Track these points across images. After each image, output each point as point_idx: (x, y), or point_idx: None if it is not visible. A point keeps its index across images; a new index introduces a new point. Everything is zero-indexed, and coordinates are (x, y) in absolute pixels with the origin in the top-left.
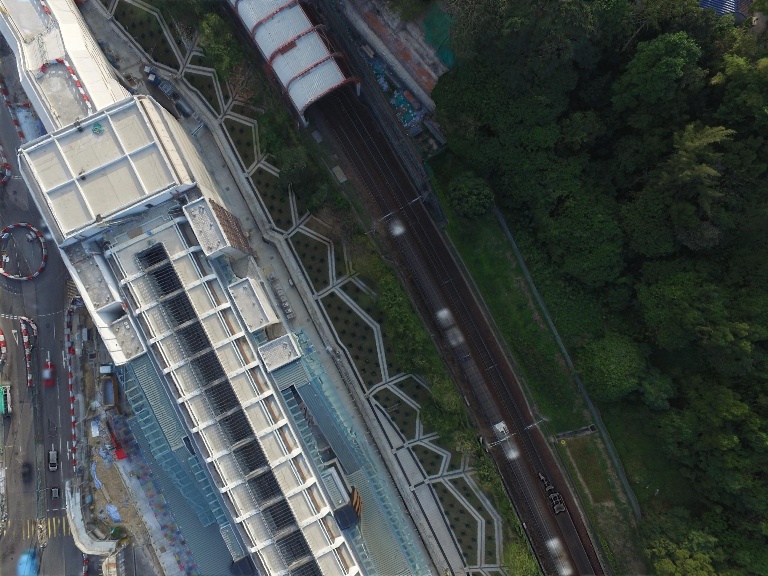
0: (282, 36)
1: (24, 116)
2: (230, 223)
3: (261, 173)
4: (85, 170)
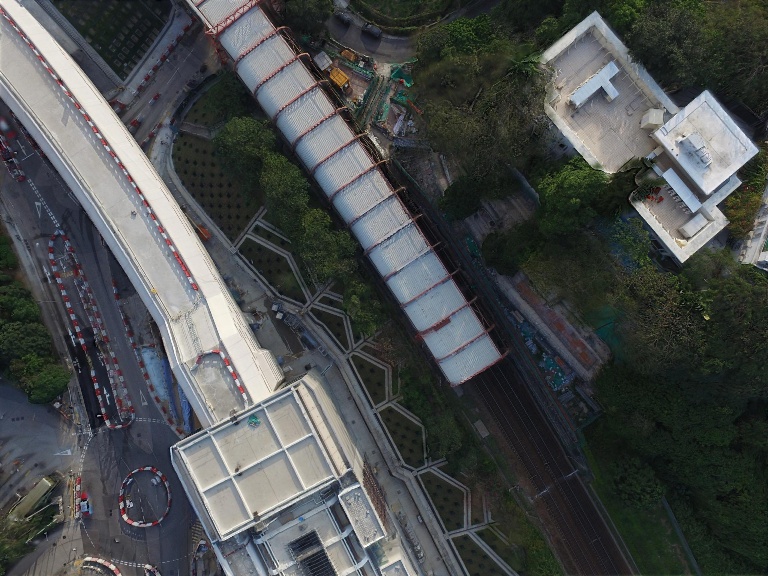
0: (436, 312)
1: (150, 358)
2: (374, 488)
3: (391, 412)
4: (241, 465)
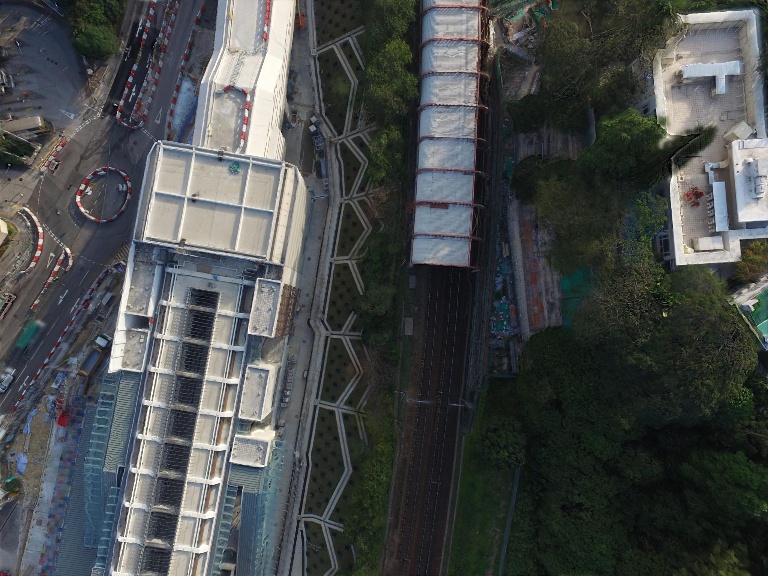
0: (441, 192)
1: (187, 87)
2: (289, 306)
3: (345, 269)
4: (200, 194)
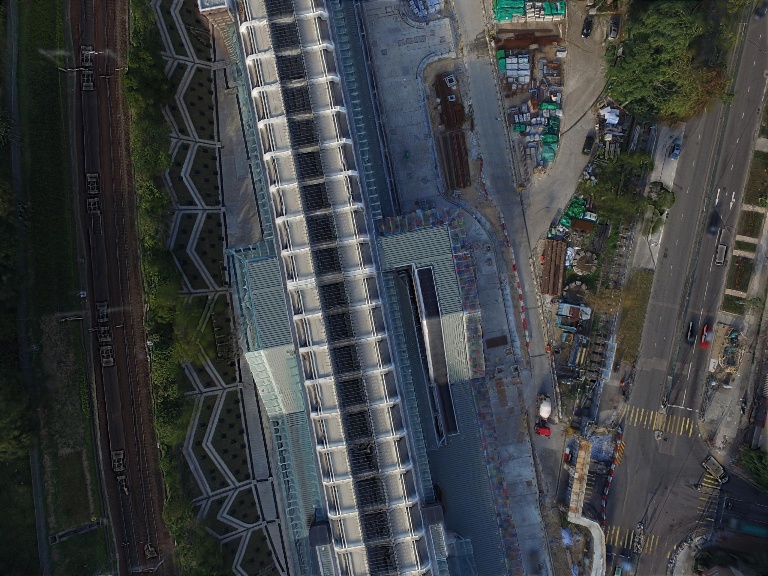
0: None
1: None
2: None
3: None
4: None
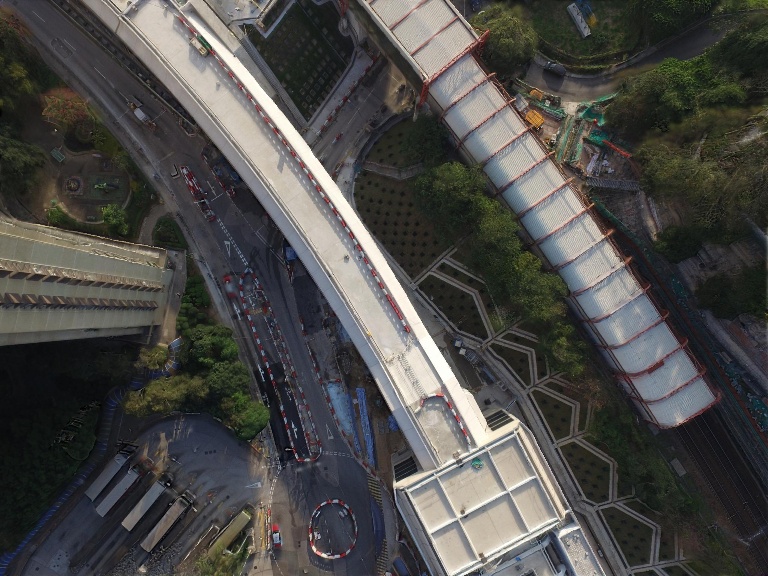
0: (649, 355)
1: (336, 393)
2: None
3: (574, 447)
4: (466, 507)
